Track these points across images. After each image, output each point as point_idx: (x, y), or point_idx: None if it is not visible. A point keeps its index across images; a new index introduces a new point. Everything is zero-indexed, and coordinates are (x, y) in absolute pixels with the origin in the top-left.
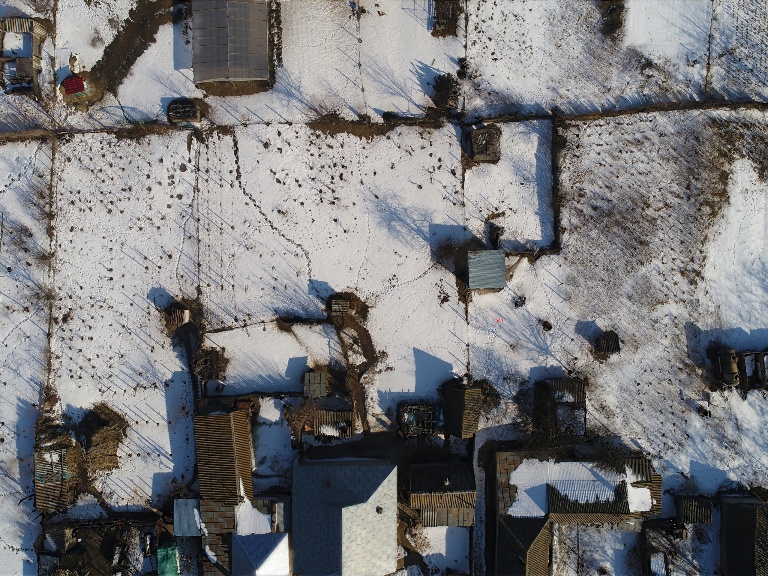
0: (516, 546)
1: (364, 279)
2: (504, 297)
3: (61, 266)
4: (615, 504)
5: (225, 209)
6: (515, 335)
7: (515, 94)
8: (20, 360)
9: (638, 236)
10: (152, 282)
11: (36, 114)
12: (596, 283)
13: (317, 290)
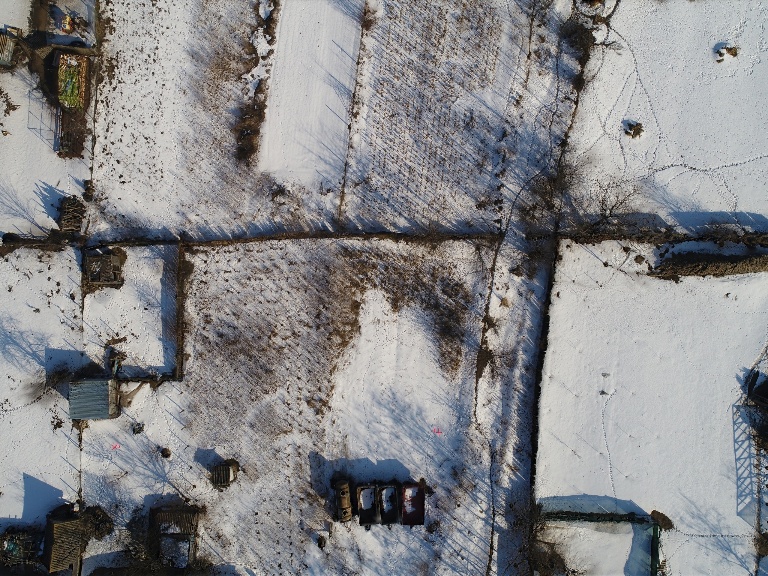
0: None
1: None
2: (122, 423)
3: None
4: None
5: None
6: (132, 462)
7: (143, 218)
8: None
9: (264, 364)
10: None
11: None
12: (219, 411)
13: None
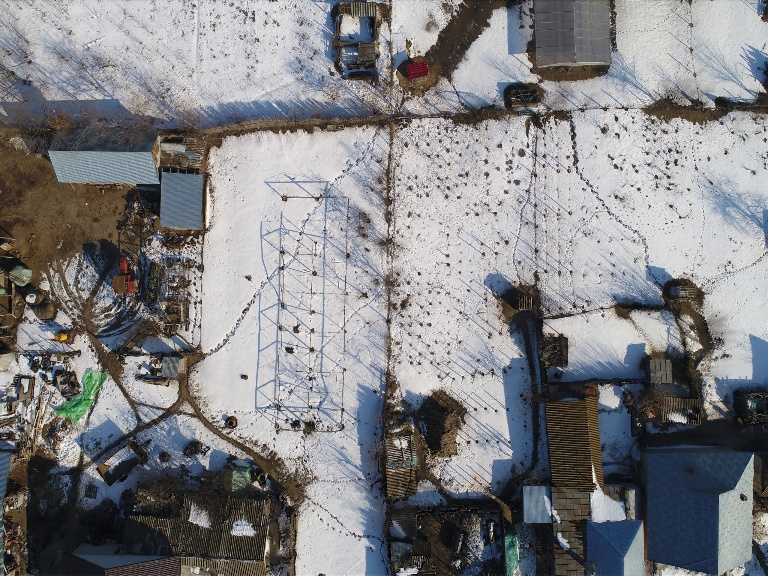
0: None
1: (700, 265)
2: None
3: (399, 252)
4: None
5: (562, 195)
6: None
7: None
8: (360, 346)
9: None
10: (489, 268)
11: (373, 99)
12: None
13: (654, 276)
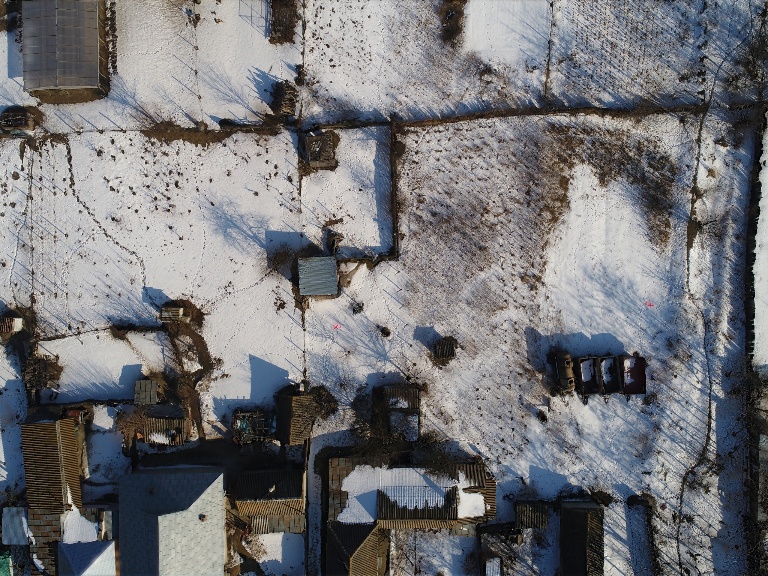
0: (341, 553)
1: (199, 286)
2: (342, 303)
3: None
4: (443, 510)
5: (59, 217)
6: (353, 341)
7: (354, 101)
8: None
9: (477, 242)
10: None
11: None
12: (435, 289)
13: (151, 297)
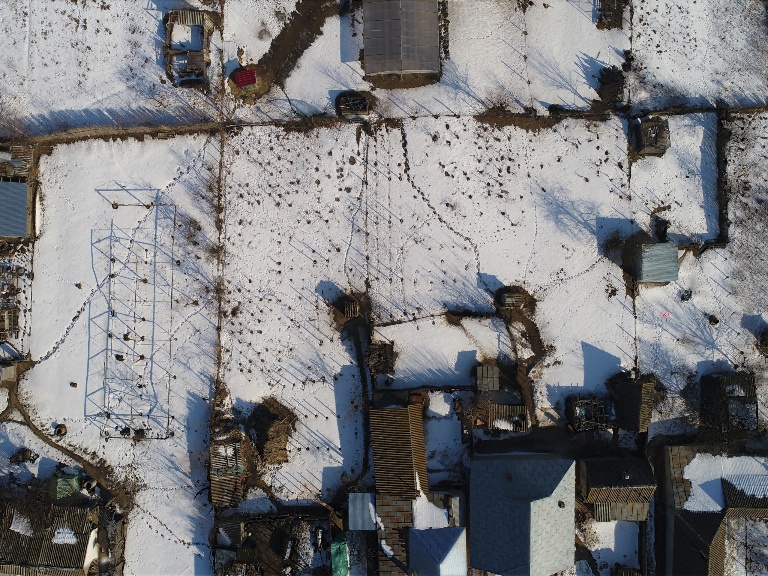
0: (696, 541)
1: (532, 273)
2: (670, 291)
3: (230, 259)
4: None
5: (393, 202)
6: (681, 329)
7: (679, 87)
8: (190, 354)
9: None
10: (320, 275)
11: (205, 107)
12: (761, 277)
13: (486, 284)
